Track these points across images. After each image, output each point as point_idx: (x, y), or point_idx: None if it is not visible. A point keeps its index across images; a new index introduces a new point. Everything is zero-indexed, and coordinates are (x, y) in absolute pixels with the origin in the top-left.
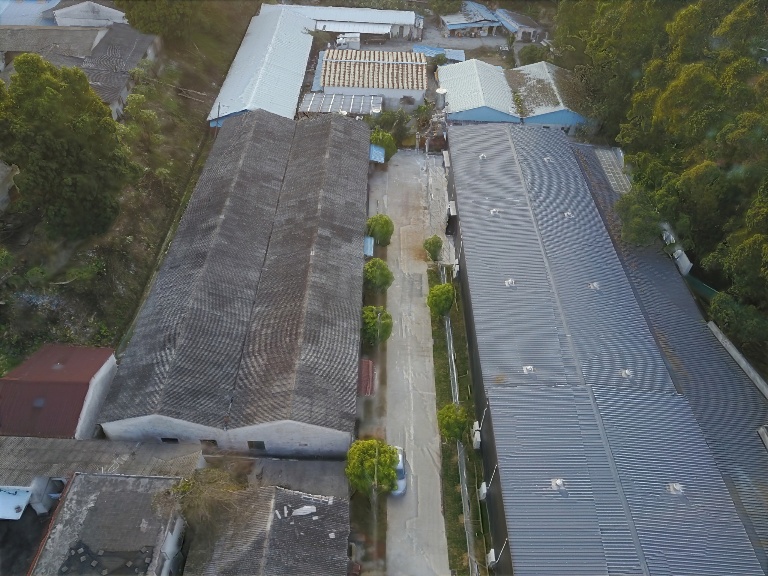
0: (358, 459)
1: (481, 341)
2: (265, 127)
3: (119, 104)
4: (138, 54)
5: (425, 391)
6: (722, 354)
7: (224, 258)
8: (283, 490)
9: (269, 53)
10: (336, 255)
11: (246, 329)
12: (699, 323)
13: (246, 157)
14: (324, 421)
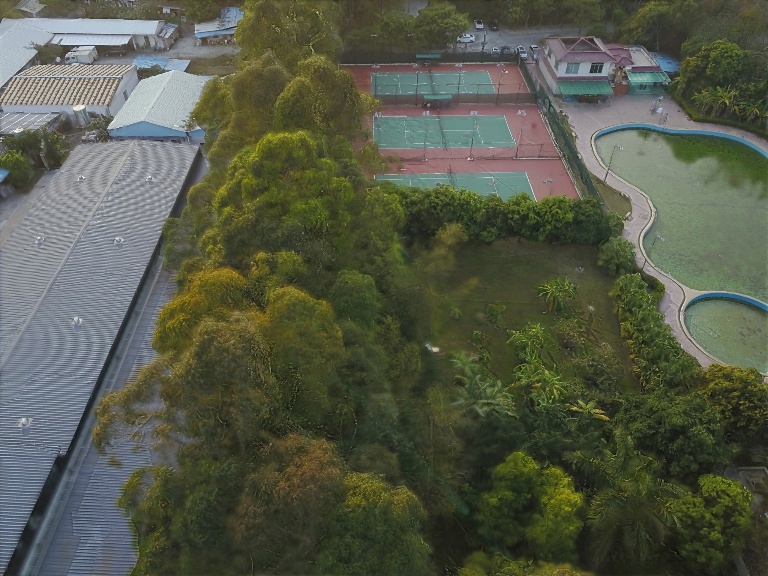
0: None
1: None
2: None
3: None
4: None
5: None
6: None
7: None
8: None
9: None
10: None
11: None
12: None
13: None
14: None
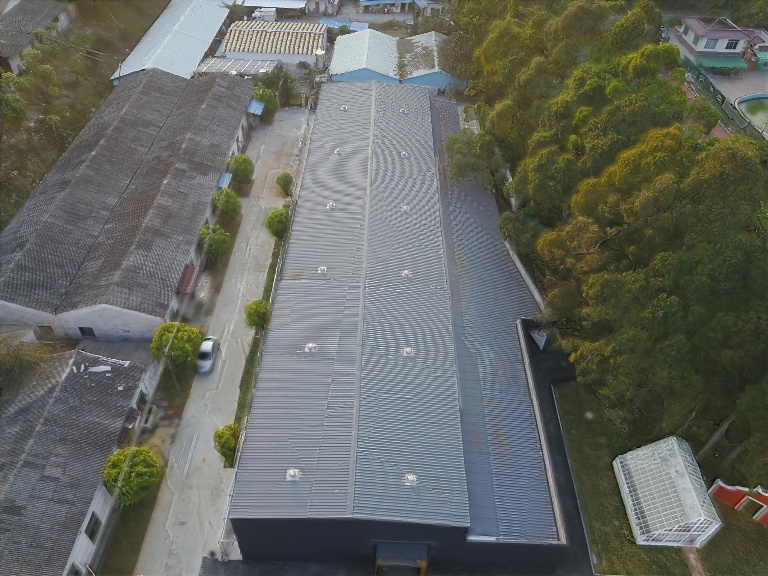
0: (158, 335)
1: (290, 249)
2: (156, 83)
3: (22, 60)
4: (47, 18)
5: (252, 298)
6: (509, 266)
7: (87, 185)
8: (84, 353)
9: (180, 22)
10: (188, 185)
11: (94, 241)
12: (498, 242)
13: (130, 106)
14: (138, 307)
